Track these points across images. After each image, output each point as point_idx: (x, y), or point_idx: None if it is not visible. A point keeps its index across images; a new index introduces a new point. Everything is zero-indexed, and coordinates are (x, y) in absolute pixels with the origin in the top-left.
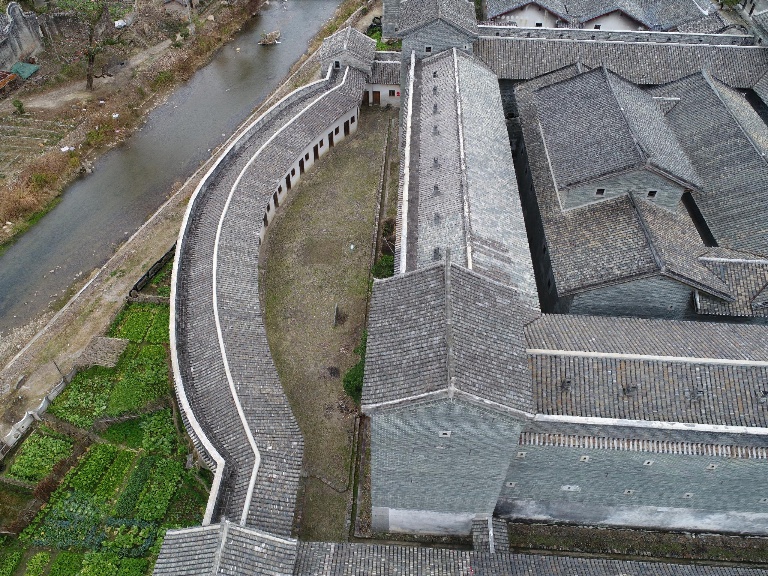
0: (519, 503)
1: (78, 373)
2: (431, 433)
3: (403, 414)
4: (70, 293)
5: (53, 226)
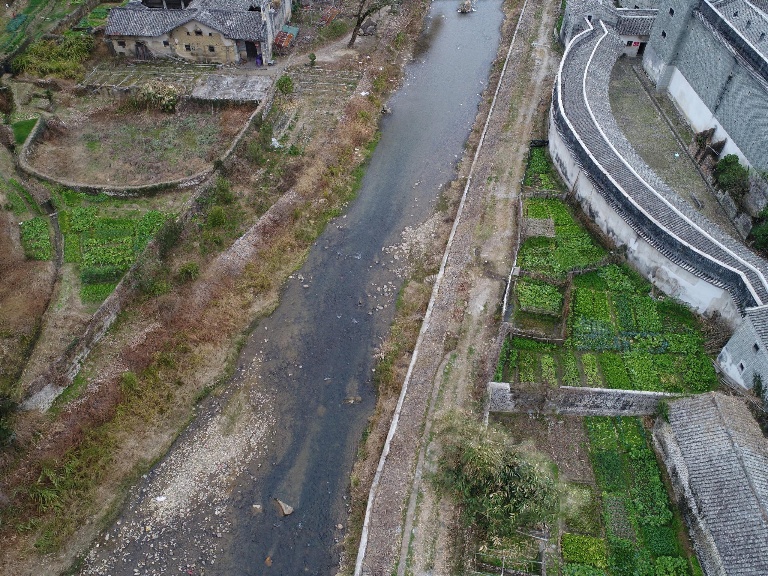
0: None
1: None
2: None
3: None
4: (444, 199)
5: (389, 152)
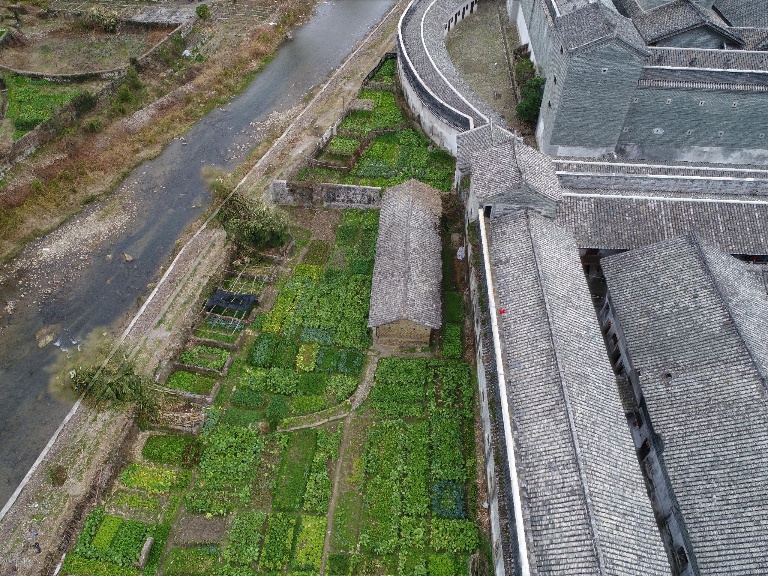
0: (627, 149)
1: (346, 117)
2: (598, 70)
3: (587, 55)
4: (311, 95)
5: (281, 65)
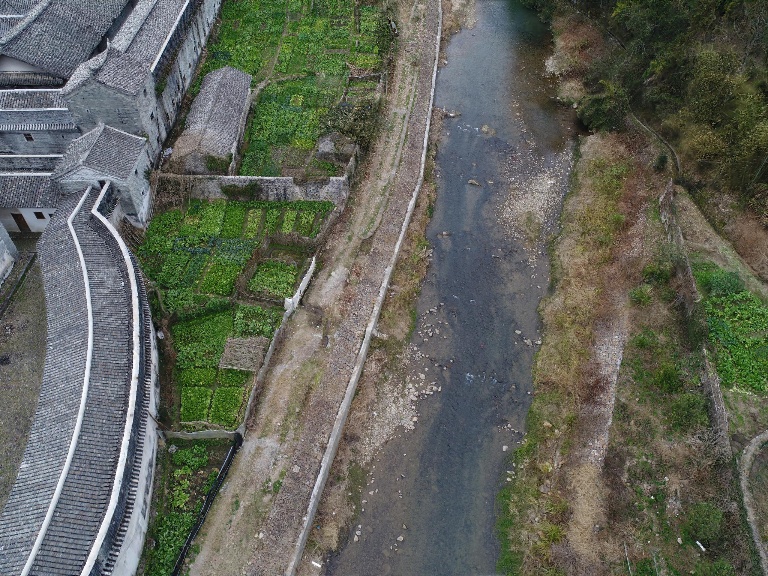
0: None
1: None
2: None
3: None
4: (354, 498)
5: None
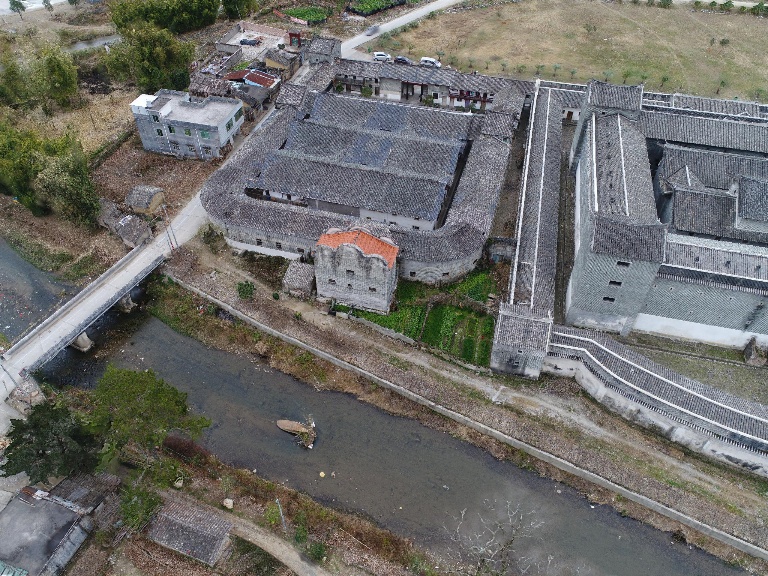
0: None
1: None
2: None
3: None
4: None
5: None
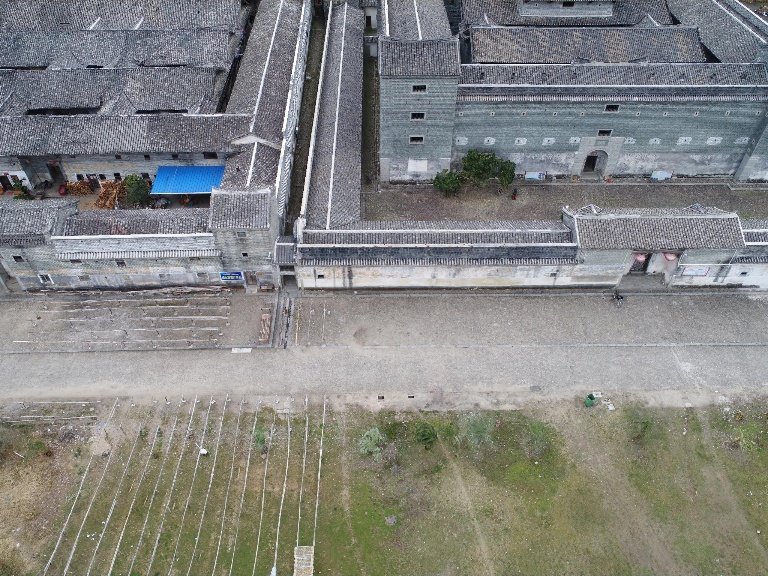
0: None
1: None
2: None
3: None
4: None
5: None
